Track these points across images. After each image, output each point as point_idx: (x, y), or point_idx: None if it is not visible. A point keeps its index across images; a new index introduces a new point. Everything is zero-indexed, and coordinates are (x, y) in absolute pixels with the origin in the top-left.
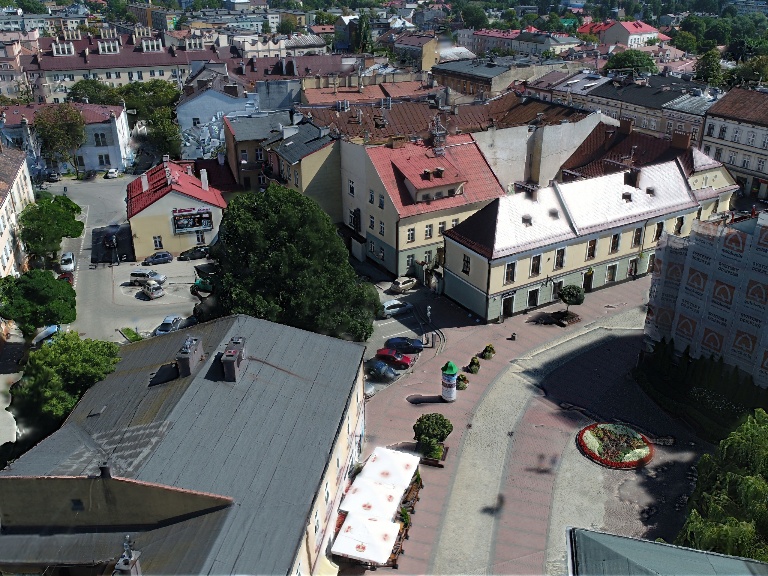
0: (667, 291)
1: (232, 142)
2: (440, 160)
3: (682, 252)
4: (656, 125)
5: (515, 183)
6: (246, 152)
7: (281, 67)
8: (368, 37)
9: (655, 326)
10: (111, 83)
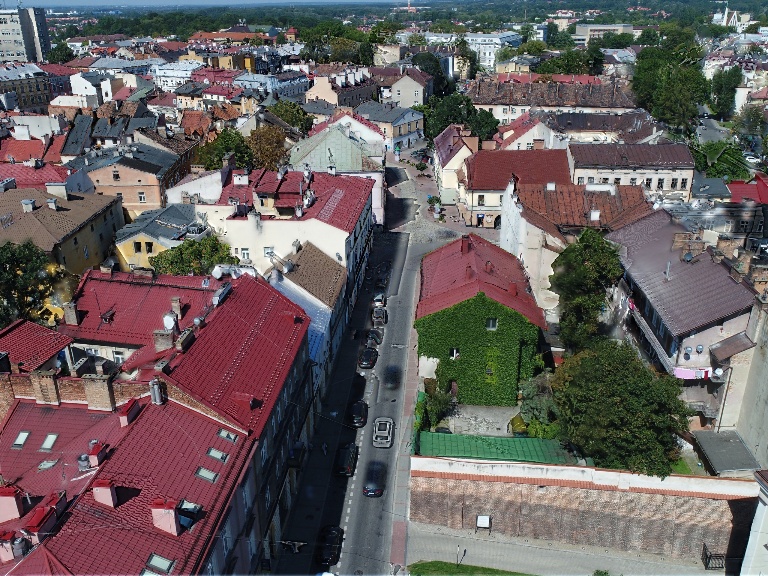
0: None
1: None
2: None
3: None
4: None
5: None
6: None
7: None
8: None
9: None
10: None
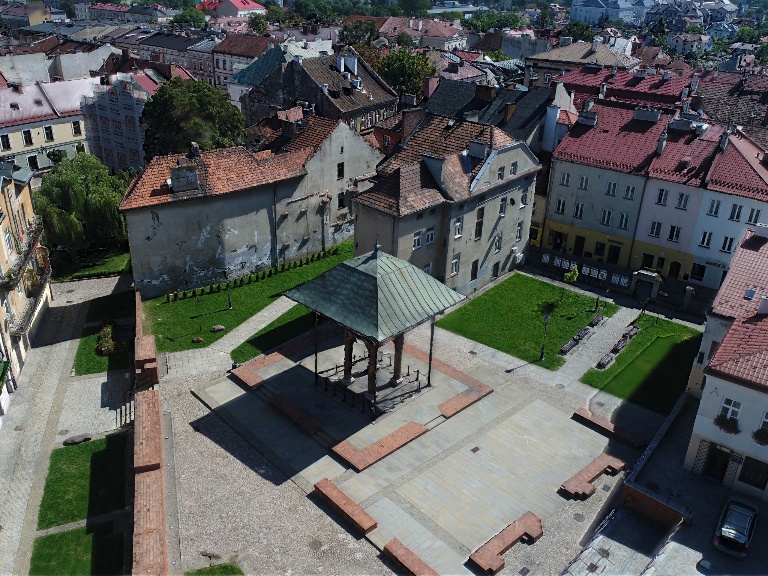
0: (94, 134)
1: None
2: None
3: (93, 106)
4: (187, 64)
5: (7, 83)
6: None
7: None
8: None
9: None
10: None
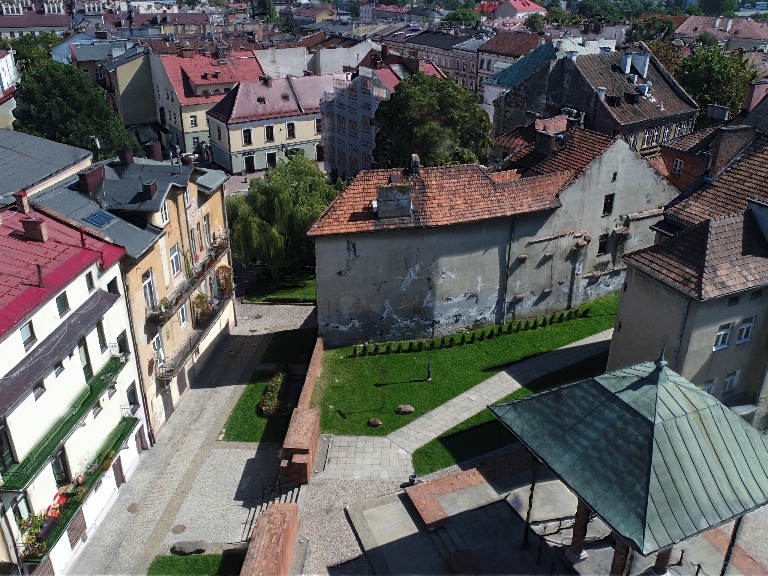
0: (330, 134)
1: (75, 63)
2: (222, 67)
3: (332, 104)
4: (450, 63)
5: (259, 76)
6: (88, 71)
7: (156, 22)
8: (249, 2)
9: (328, 162)
10: (5, 35)
